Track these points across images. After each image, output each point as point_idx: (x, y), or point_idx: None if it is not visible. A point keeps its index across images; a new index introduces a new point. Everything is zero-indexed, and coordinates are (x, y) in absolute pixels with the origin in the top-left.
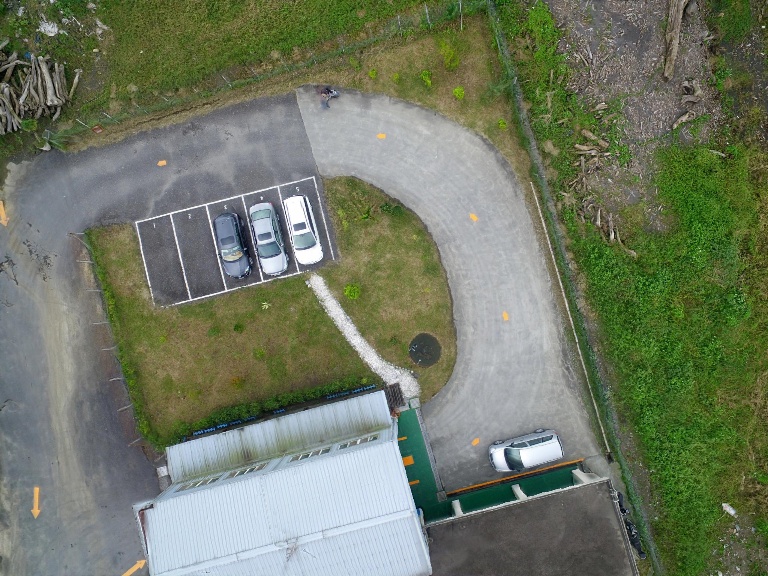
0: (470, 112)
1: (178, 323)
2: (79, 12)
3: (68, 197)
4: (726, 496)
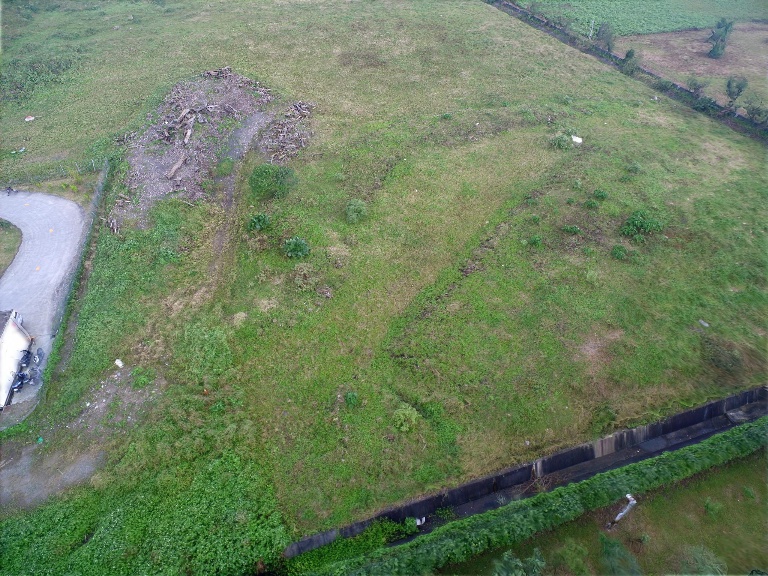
0: None
1: None
2: None
3: None
4: (120, 354)
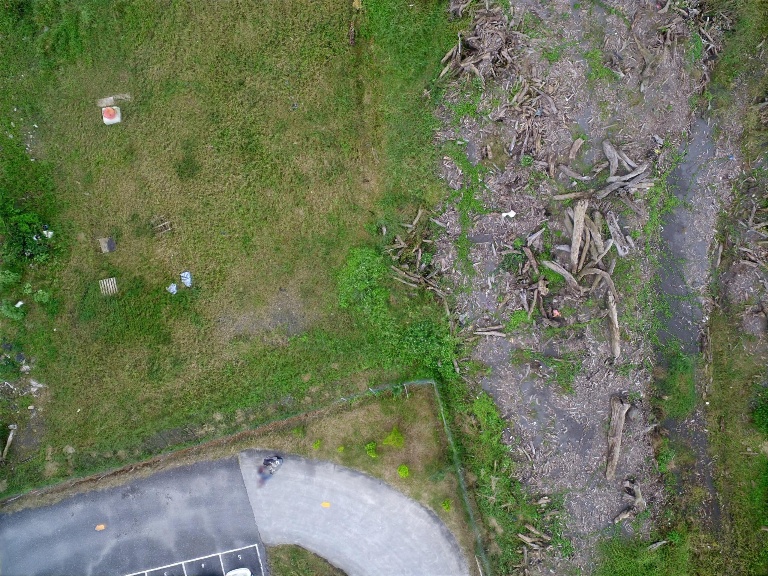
0: (415, 483)
1: None
2: (11, 378)
3: (2, 560)
4: None
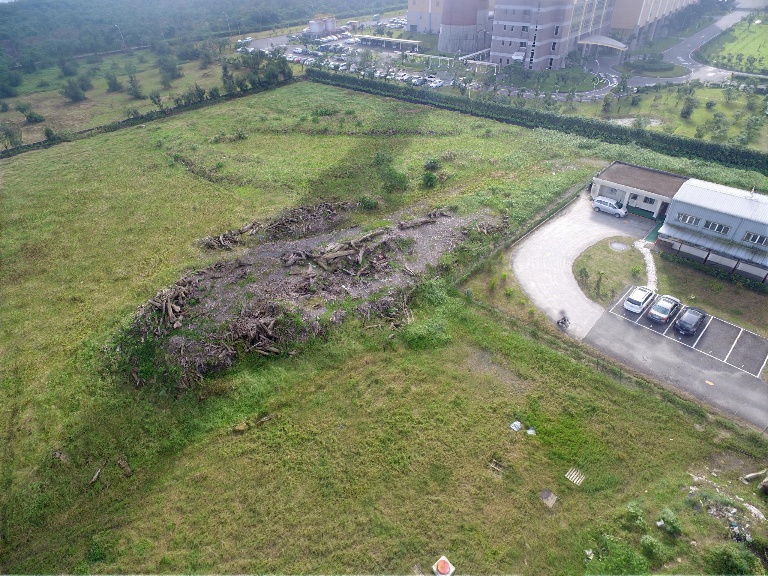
0: None
1: (761, 329)
2: None
3: None
4: None
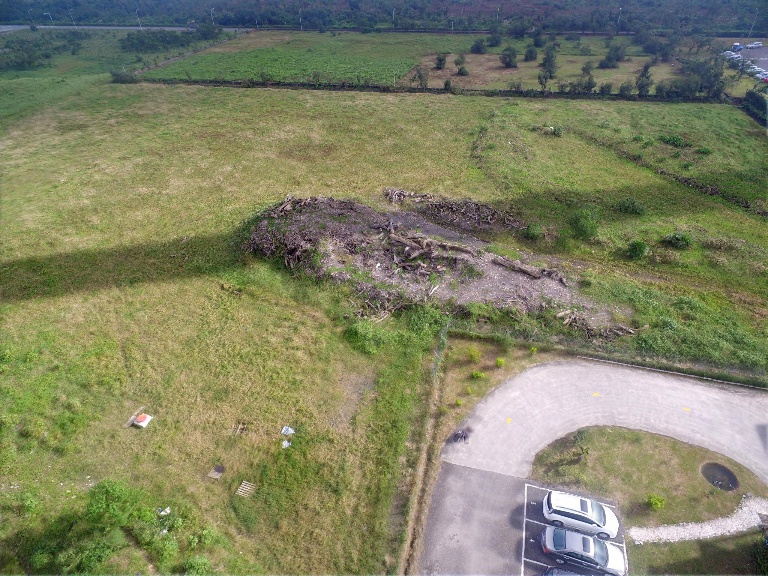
0: (513, 365)
1: None
2: None
3: None
4: None
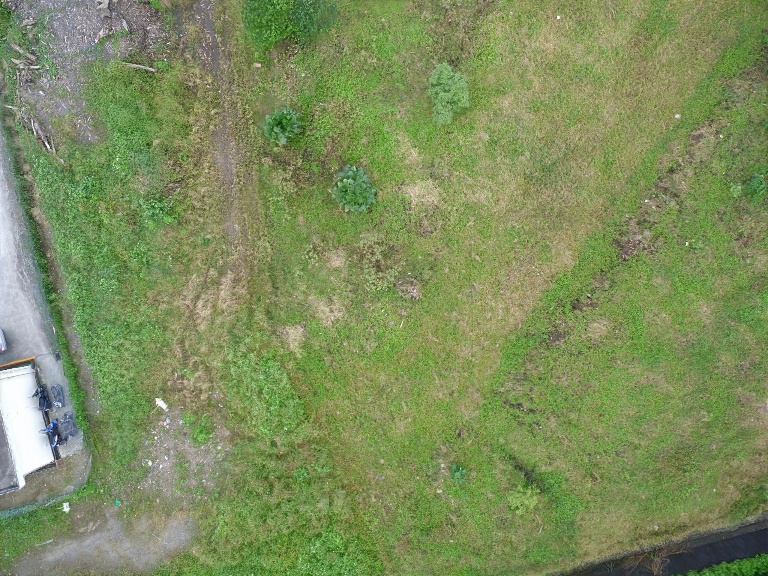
0: None
1: None
2: None
3: None
4: (158, 391)
